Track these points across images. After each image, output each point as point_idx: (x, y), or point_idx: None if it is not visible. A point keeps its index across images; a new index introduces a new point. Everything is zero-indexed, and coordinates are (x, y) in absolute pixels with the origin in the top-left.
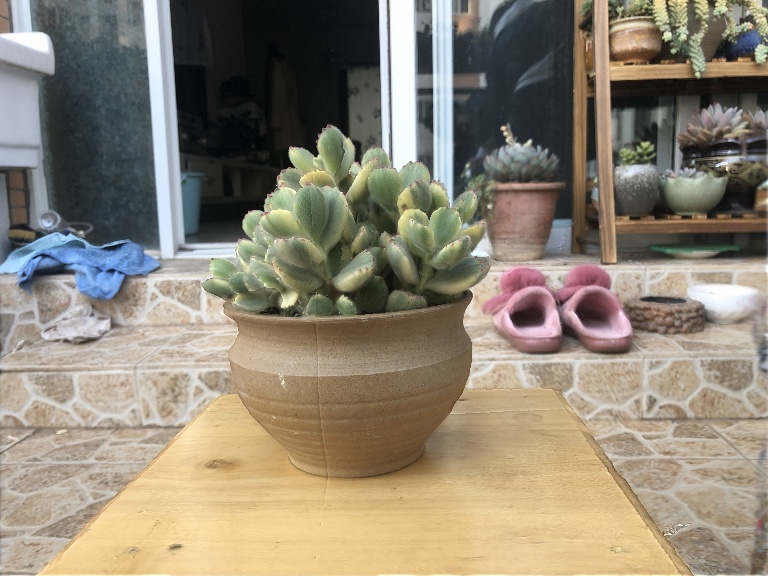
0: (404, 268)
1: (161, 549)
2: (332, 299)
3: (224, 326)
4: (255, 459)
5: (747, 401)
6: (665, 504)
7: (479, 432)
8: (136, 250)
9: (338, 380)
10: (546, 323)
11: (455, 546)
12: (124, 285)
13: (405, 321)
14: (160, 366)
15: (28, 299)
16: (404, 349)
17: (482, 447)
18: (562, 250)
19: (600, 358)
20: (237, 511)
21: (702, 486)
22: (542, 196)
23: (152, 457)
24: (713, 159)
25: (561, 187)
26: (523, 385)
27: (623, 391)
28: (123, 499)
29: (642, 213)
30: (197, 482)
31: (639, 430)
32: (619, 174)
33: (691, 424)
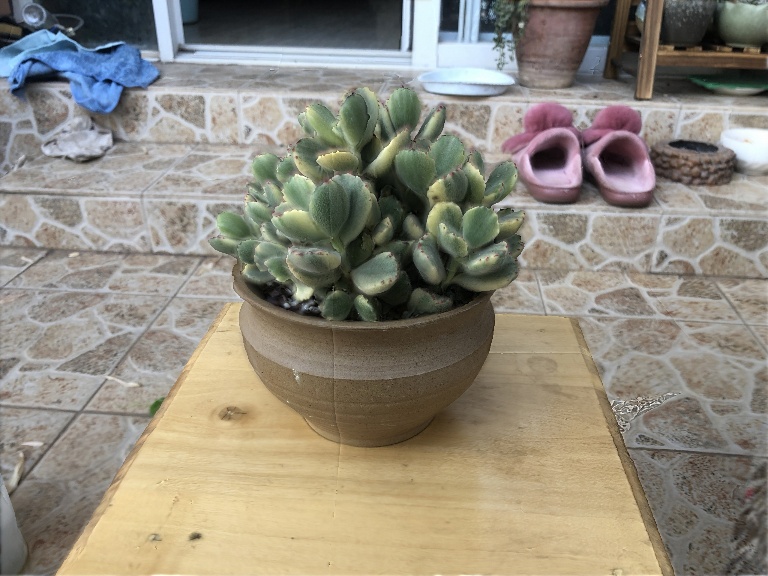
0: (431, 276)
1: (181, 539)
2: (350, 295)
3: (230, 147)
4: (268, 409)
5: (759, 262)
6: (659, 371)
7: (492, 384)
8: (133, 54)
9: (354, 383)
10: (567, 168)
11: (463, 558)
12: (123, 97)
13: (428, 327)
14: (167, 195)
15: (23, 107)
16: (425, 350)
17: (494, 408)
18: (594, 72)
19: (618, 211)
20: (252, 488)
21: (697, 353)
22: (581, 15)
23: (165, 289)
24: None
25: (604, 4)
26: (535, 234)
27: (635, 245)
28: (141, 462)
29: (689, 43)
30: (212, 441)
31: (645, 285)
32: None
33: (698, 281)
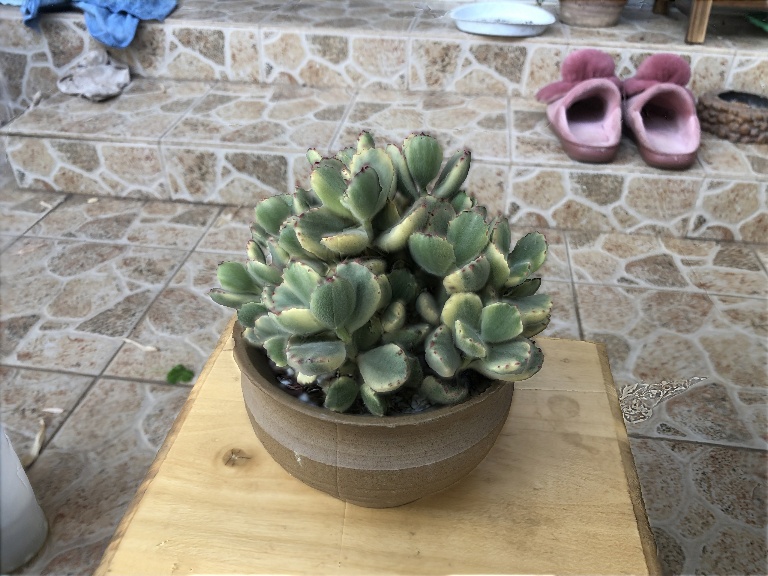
0: None
1: None
2: (356, 381)
3: (251, 86)
4: None
5: None
6: (686, 351)
7: (509, 429)
8: None
9: (359, 472)
10: (605, 122)
11: None
12: (139, 31)
13: (439, 420)
14: (185, 143)
15: (37, 38)
16: (435, 438)
17: (509, 462)
18: (642, 6)
19: (657, 173)
20: (253, 556)
21: (729, 332)
22: None
23: (183, 242)
24: None
25: None
26: (567, 194)
27: (673, 209)
28: (141, 517)
29: None
30: (214, 492)
31: (679, 252)
32: None
33: (736, 249)
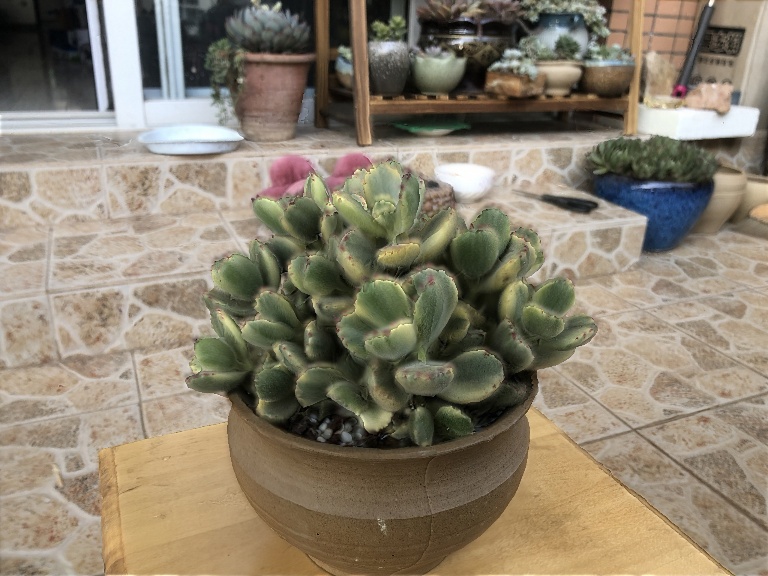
0: None
1: None
2: (430, 409)
3: None
4: (269, 573)
5: None
6: None
7: None
8: None
9: (455, 512)
10: None
11: None
12: None
13: None
14: None
15: None
16: (506, 448)
17: None
18: (304, 123)
19: None
20: None
21: None
22: (295, 70)
23: None
24: (450, 37)
25: (312, 59)
26: None
27: None
28: None
29: (394, 93)
30: None
31: None
32: (374, 51)
33: None
